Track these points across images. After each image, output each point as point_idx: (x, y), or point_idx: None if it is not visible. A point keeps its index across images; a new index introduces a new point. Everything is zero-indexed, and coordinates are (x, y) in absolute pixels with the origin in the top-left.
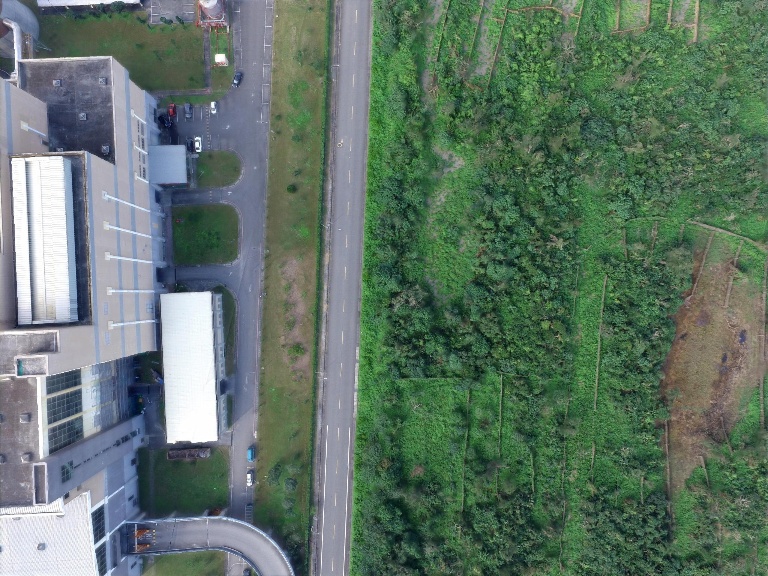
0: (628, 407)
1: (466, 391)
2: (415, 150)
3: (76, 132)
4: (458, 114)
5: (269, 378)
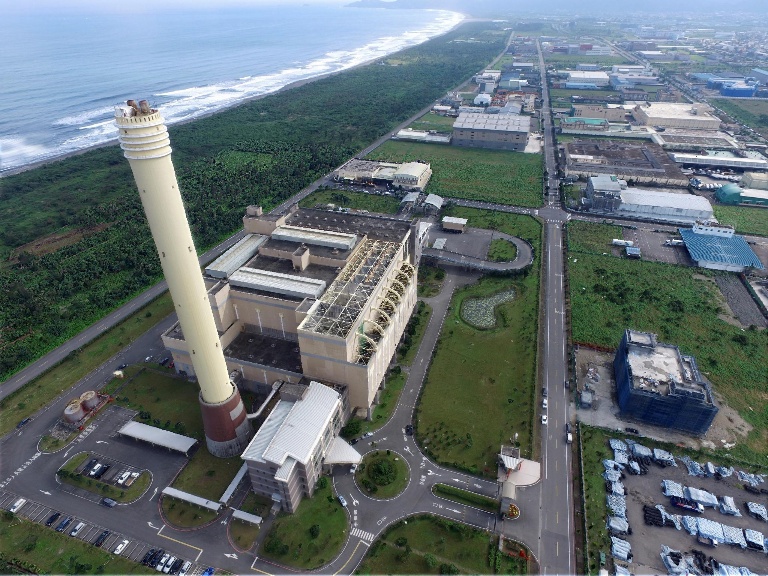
0: None
1: None
2: None
3: None
4: None
5: None
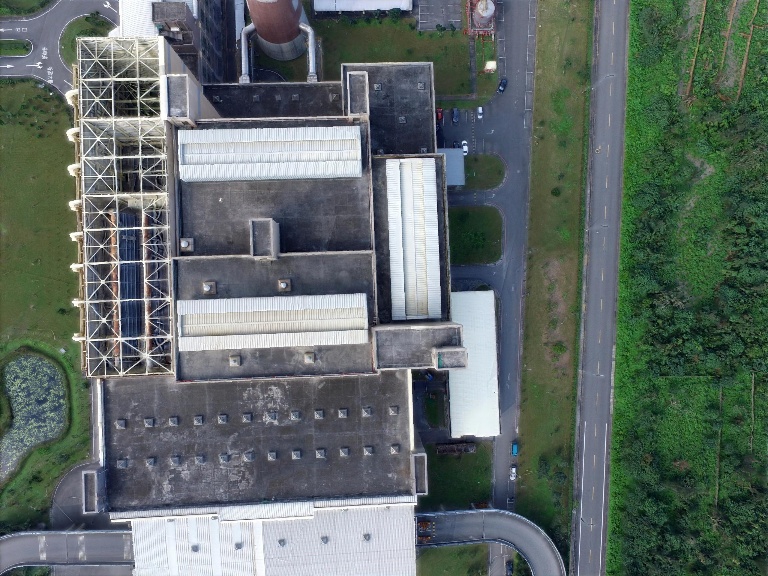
0: None
1: (717, 389)
2: (672, 157)
3: (395, 134)
4: (711, 123)
5: (531, 375)
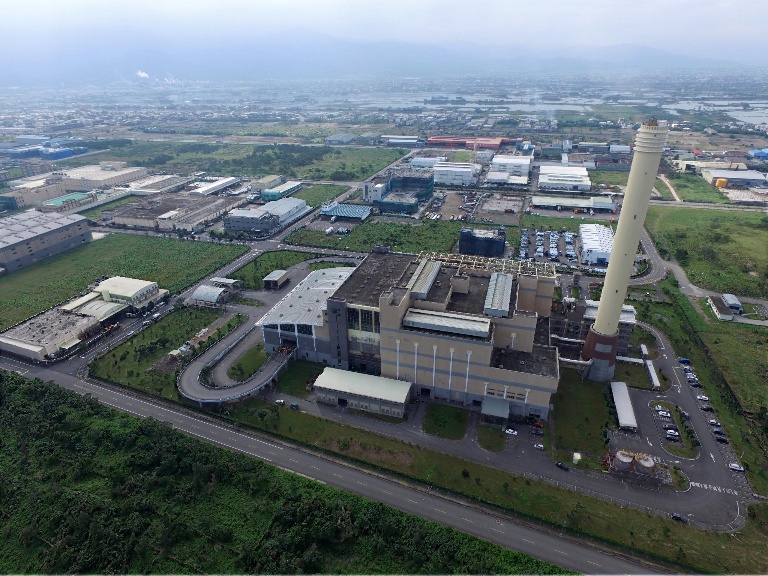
0: None
1: None
2: None
3: (513, 359)
4: None
5: (335, 427)
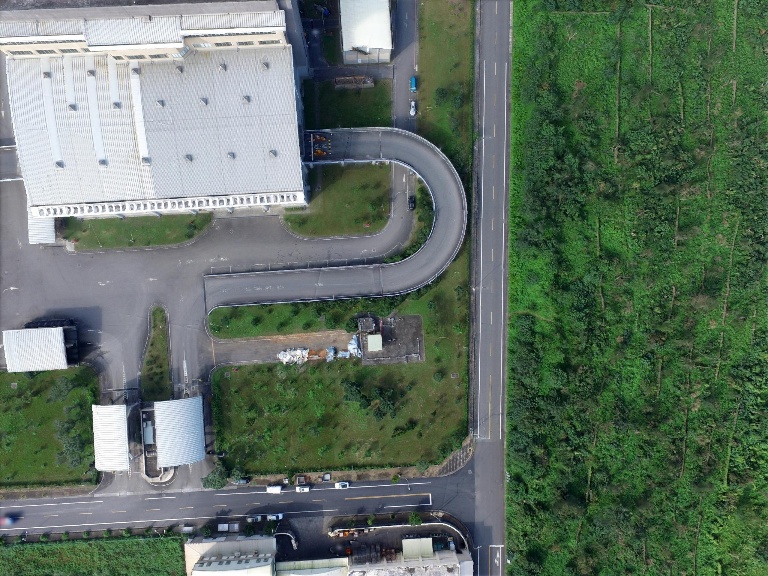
0: (764, 48)
1: (616, 27)
2: None
3: None
4: None
5: (429, 13)
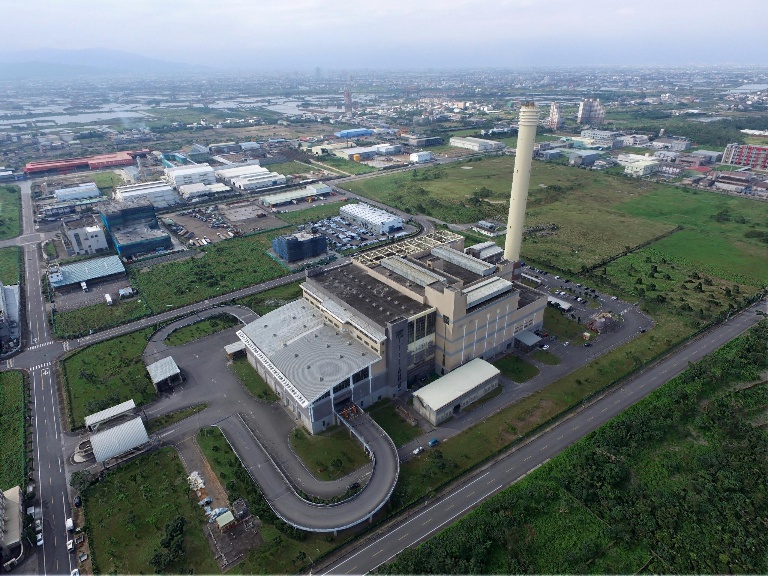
0: None
1: (611, 542)
2: None
3: None
4: None
5: (482, 427)
